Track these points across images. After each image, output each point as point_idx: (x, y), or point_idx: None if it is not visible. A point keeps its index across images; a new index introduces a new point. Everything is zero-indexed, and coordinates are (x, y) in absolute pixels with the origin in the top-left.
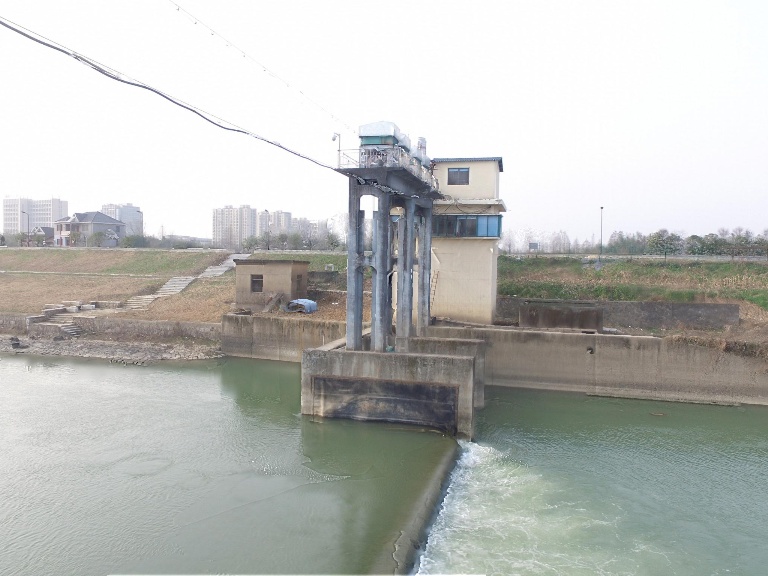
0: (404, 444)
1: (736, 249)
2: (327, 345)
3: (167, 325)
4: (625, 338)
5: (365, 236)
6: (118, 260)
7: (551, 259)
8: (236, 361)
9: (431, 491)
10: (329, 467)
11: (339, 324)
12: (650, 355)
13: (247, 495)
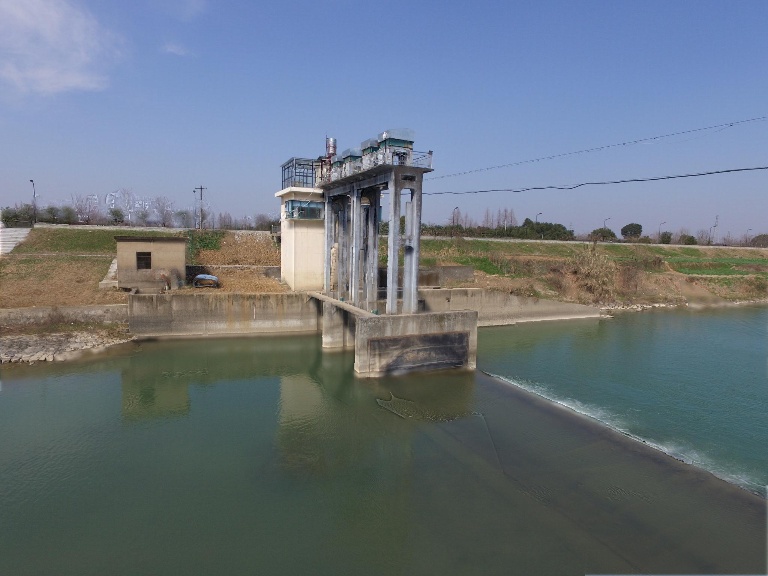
0: (453, 379)
1: (437, 232)
2: (363, 313)
3: (38, 312)
4: (465, 290)
5: (153, 213)
6: None
7: None
8: (151, 341)
9: None
10: None
11: (270, 295)
12: (477, 299)
13: (475, 439)
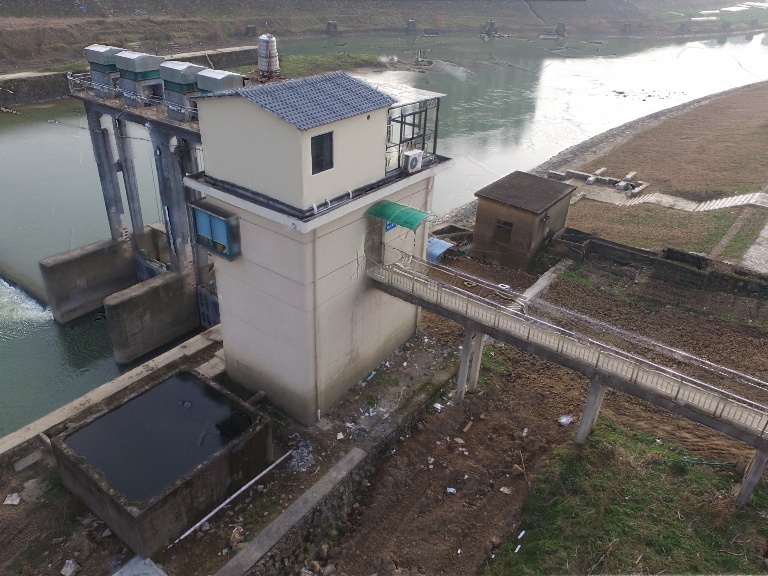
0: None
1: None
2: None
3: None
4: None
5: None
6: None
7: None
8: None
9: (6, 271)
10: None
11: None
12: None
13: None
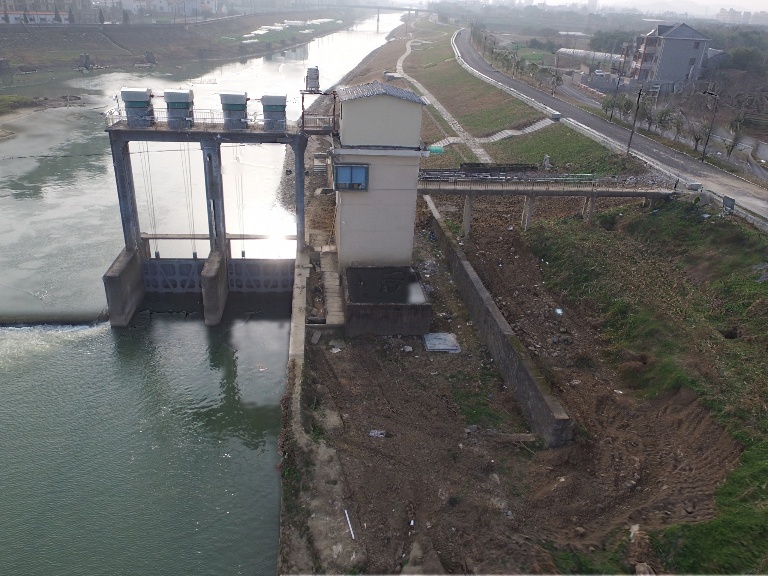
0: None
1: None
2: None
3: None
4: None
5: None
6: (489, 106)
7: (731, 233)
8: None
9: (2, 319)
10: None
11: None
12: None
13: (18, 283)
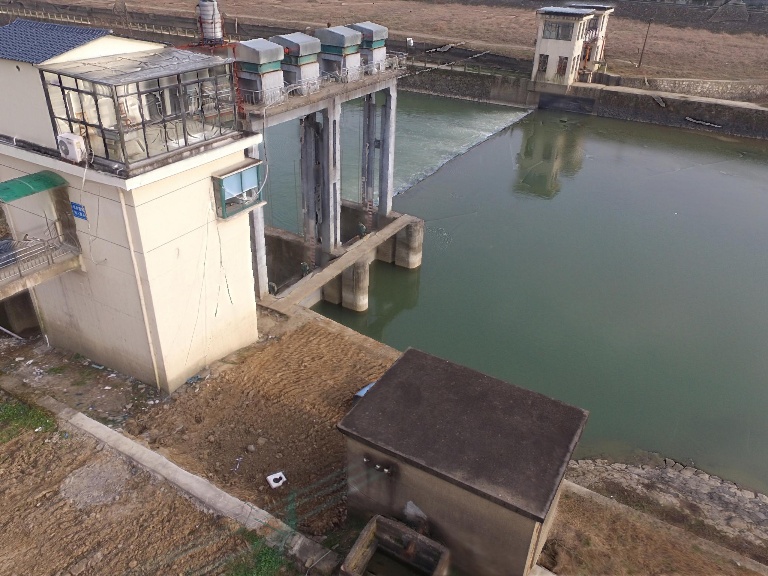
0: None
1: None
2: (403, 222)
3: None
4: None
5: None
6: None
7: None
8: None
9: None
10: (397, 302)
11: None
12: None
13: (453, 221)
